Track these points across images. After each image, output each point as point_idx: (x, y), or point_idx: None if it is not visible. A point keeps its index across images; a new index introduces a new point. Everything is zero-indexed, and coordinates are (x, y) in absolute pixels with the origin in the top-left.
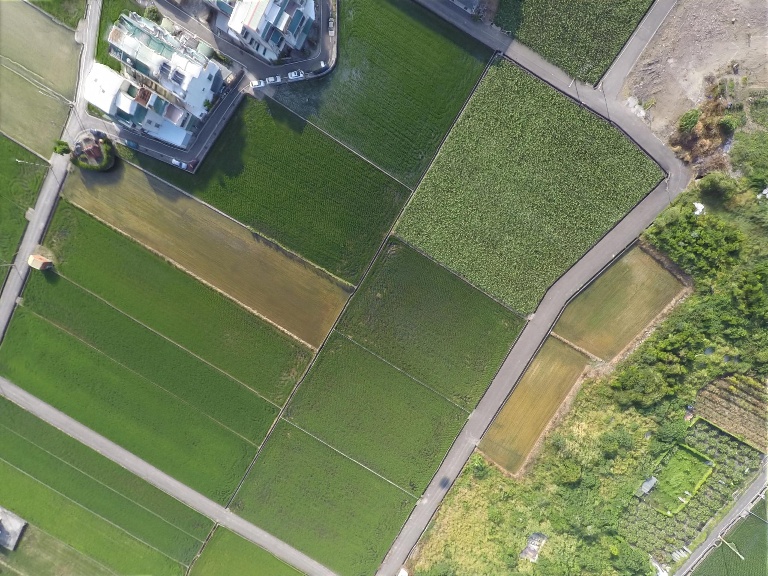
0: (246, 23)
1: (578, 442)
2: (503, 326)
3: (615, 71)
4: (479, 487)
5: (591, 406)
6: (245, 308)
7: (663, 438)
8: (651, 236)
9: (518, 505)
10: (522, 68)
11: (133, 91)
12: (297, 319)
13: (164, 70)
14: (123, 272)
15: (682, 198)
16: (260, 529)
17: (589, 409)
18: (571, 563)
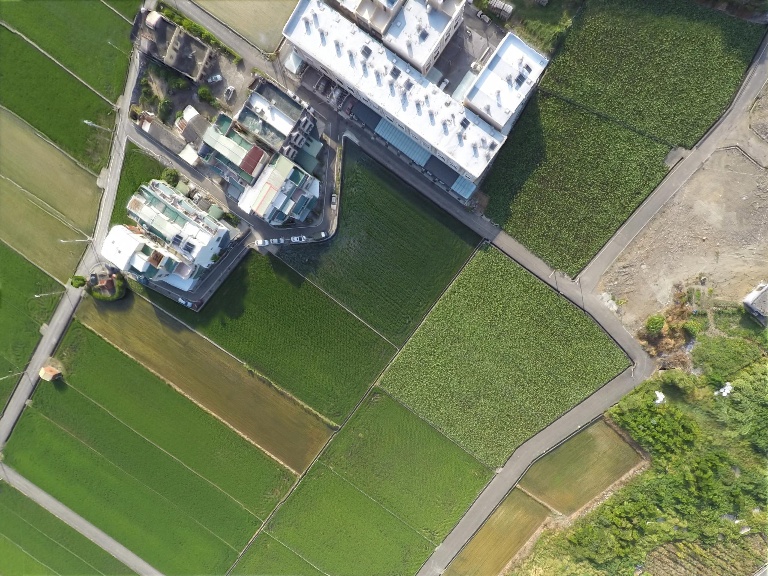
0: (254, 208)
1: None
2: (473, 475)
3: (592, 269)
4: None
5: (549, 554)
6: (236, 432)
7: None
8: (614, 415)
9: None
10: (507, 256)
11: (147, 250)
12: (284, 447)
13: (176, 240)
14: (126, 388)
15: (645, 386)
16: None
17: (547, 556)
18: None
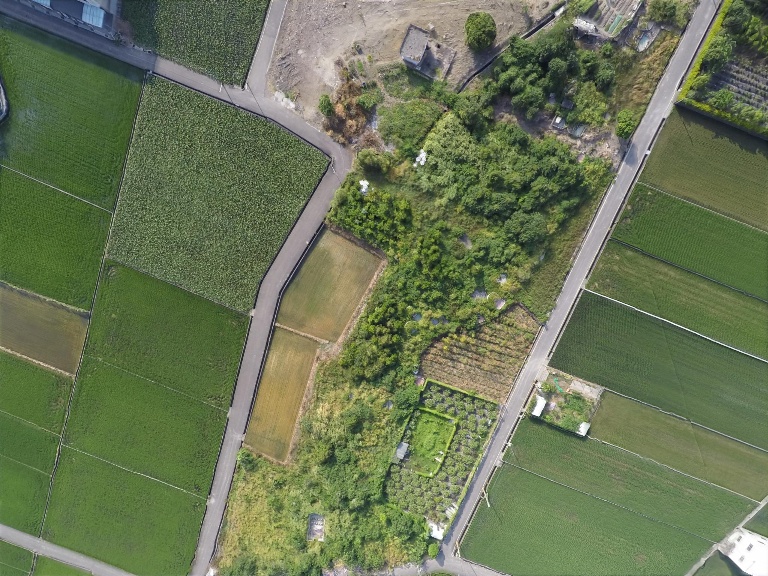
0: None
1: (324, 422)
2: (231, 325)
3: (255, 70)
4: (254, 479)
5: (329, 386)
6: None
7: (400, 405)
8: (332, 219)
9: (291, 490)
10: (173, 82)
11: None
12: (49, 351)
13: None
14: None
15: (348, 178)
16: (75, 552)
17: (329, 390)
18: (351, 536)
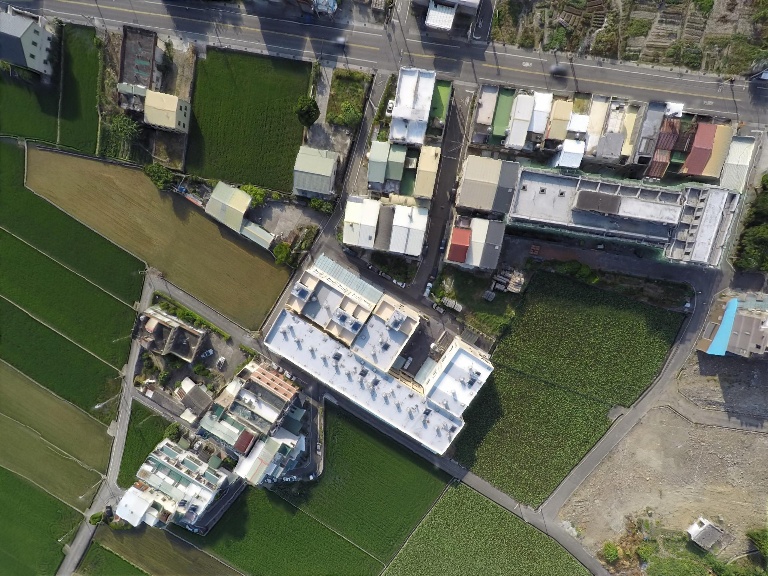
0: (248, 478)
1: None
2: None
3: (552, 502)
4: None
5: None
6: None
7: None
8: None
9: None
10: (476, 491)
11: (156, 505)
12: None
13: (181, 503)
14: None
15: None
16: None
17: None
18: None
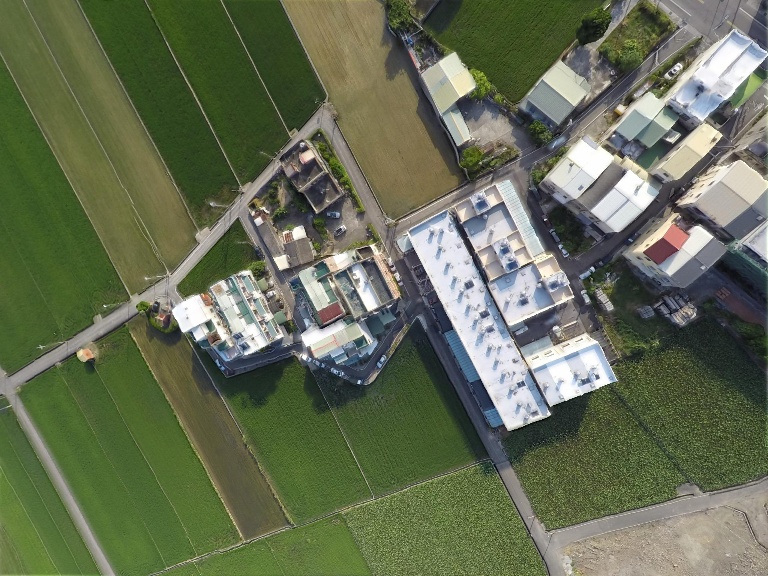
0: (313, 348)
1: None
2: None
3: (568, 533)
4: None
5: None
6: (210, 481)
7: None
8: None
9: None
10: (502, 482)
11: (210, 324)
12: (242, 513)
13: (237, 335)
14: (140, 398)
15: None
16: None
17: None
18: None
